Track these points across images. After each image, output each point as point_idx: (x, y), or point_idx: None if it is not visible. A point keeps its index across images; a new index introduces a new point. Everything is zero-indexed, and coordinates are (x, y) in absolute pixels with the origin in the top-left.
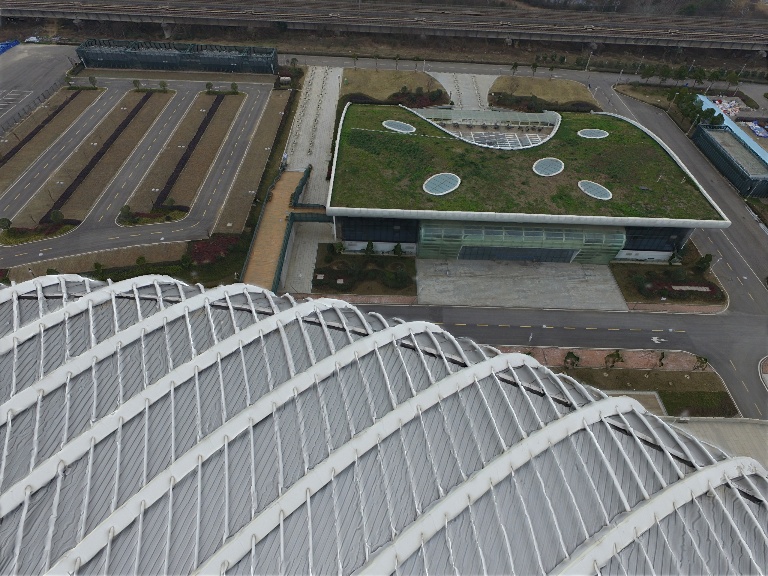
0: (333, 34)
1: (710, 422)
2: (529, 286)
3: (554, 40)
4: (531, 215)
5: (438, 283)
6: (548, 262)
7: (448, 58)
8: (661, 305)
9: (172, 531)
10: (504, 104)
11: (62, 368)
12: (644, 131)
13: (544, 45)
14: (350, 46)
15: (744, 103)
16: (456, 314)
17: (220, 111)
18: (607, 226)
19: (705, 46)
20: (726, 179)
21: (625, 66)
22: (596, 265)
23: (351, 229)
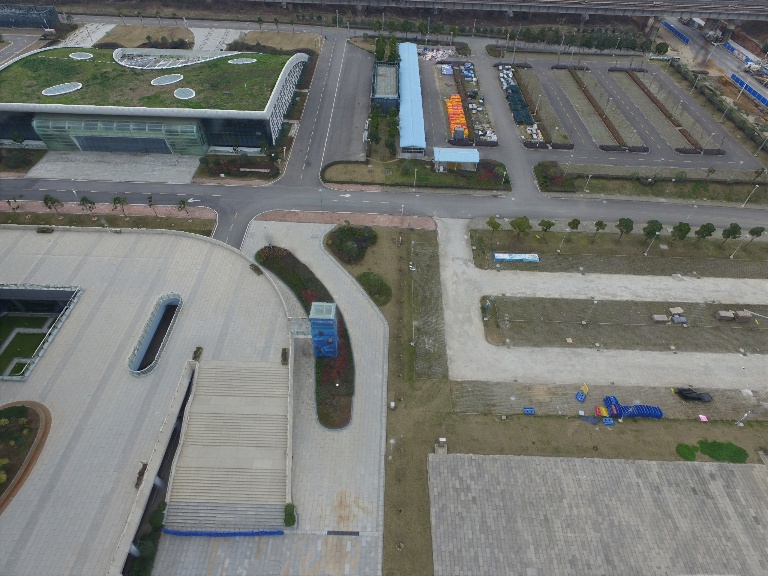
0: None
1: (139, 233)
2: (124, 168)
3: (324, 3)
4: (106, 107)
5: (52, 165)
6: (155, 153)
7: (217, 17)
8: (219, 180)
9: None
10: None
11: None
12: None
13: None
14: (139, 9)
15: (455, 51)
16: (47, 184)
17: None
18: (181, 119)
19: (459, 7)
20: None
21: None
22: (194, 156)
23: (0, 128)
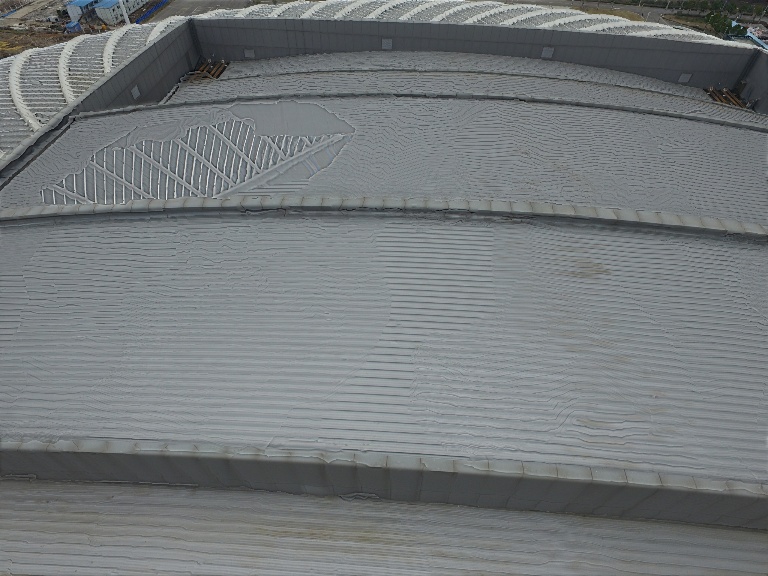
0: None
1: None
2: None
3: None
4: None
5: None
6: None
7: None
8: None
9: None
10: None
11: (472, 3)
12: None
13: None
14: None
15: (766, 28)
16: None
17: None
18: None
19: None
20: None
21: (671, 3)
22: None
23: None
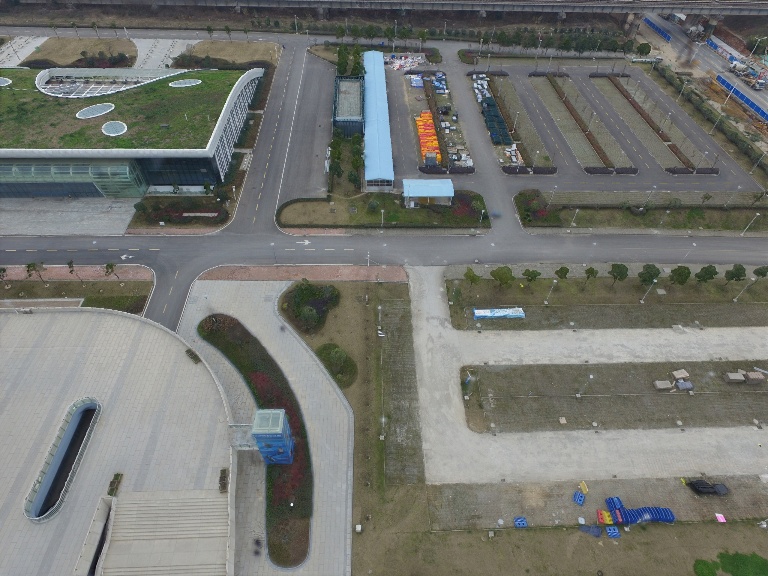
0: (64, 7)
1: (53, 312)
2: (48, 218)
3: (282, 6)
4: (19, 150)
5: None
6: (85, 197)
7: (163, 26)
8: (159, 229)
9: None
10: (183, 65)
11: None
12: None
13: (285, 12)
14: (75, 17)
15: (425, 58)
16: None
17: None
18: (110, 159)
19: (428, 8)
20: None
21: None
22: (131, 199)
23: None
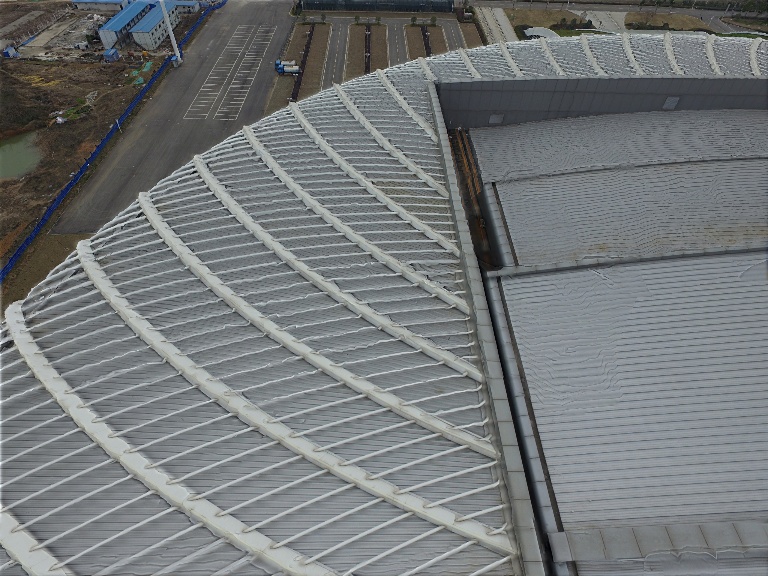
0: None
1: None
2: None
3: None
4: None
5: None
6: None
7: (581, 0)
8: None
9: None
10: None
11: (709, 40)
12: None
13: None
14: None
15: None
16: None
17: (431, 37)
18: None
19: None
20: None
21: (722, 5)
22: None
23: None
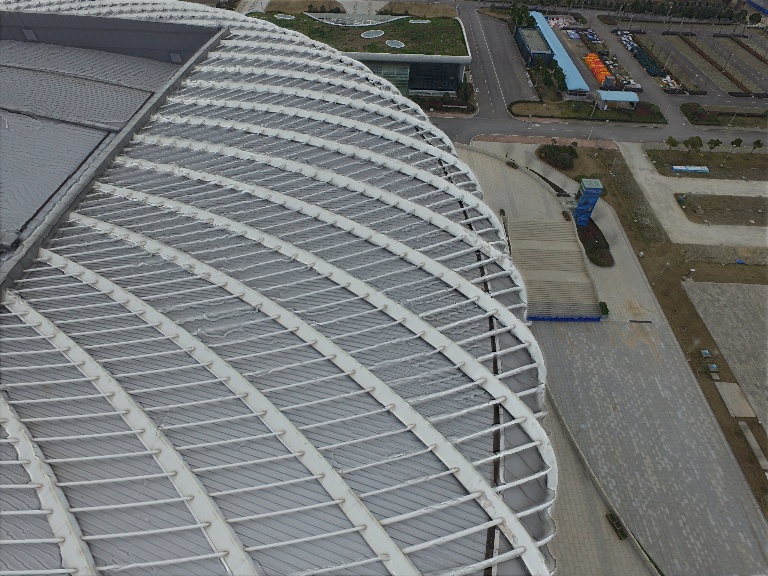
0: None
1: None
2: None
3: None
4: (342, 52)
5: None
6: None
7: None
8: (430, 113)
9: (57, 3)
10: None
11: None
12: (458, 21)
13: None
14: None
15: (574, 19)
16: None
17: None
18: (397, 63)
19: None
20: (522, 58)
21: None
22: None
23: None
